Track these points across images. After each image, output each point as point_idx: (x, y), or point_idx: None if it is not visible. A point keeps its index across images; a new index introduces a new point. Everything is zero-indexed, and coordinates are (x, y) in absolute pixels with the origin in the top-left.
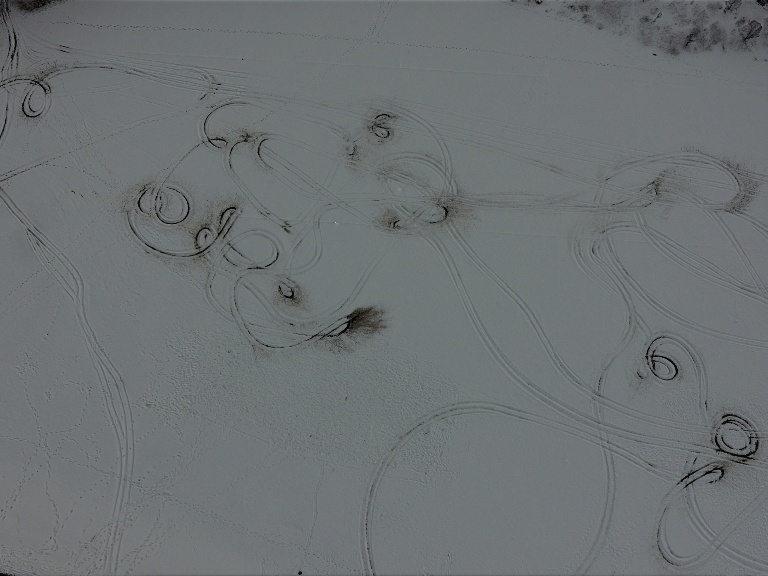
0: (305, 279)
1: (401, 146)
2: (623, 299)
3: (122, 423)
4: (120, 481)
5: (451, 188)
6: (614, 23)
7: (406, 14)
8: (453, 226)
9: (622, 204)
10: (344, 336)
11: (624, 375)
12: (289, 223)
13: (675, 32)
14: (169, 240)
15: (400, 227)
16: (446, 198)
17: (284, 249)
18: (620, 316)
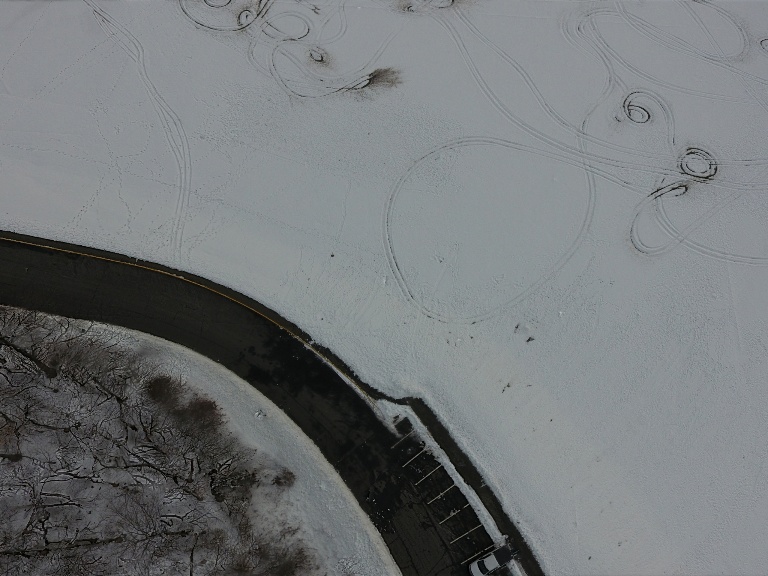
0: (333, 48)
1: None
2: (604, 64)
3: (180, 150)
4: (180, 191)
5: None
6: None
7: None
8: (459, 10)
9: None
10: (366, 89)
11: (604, 119)
12: (318, 7)
13: None
14: (215, 19)
15: (413, 11)
16: None
17: (314, 26)
18: (601, 76)
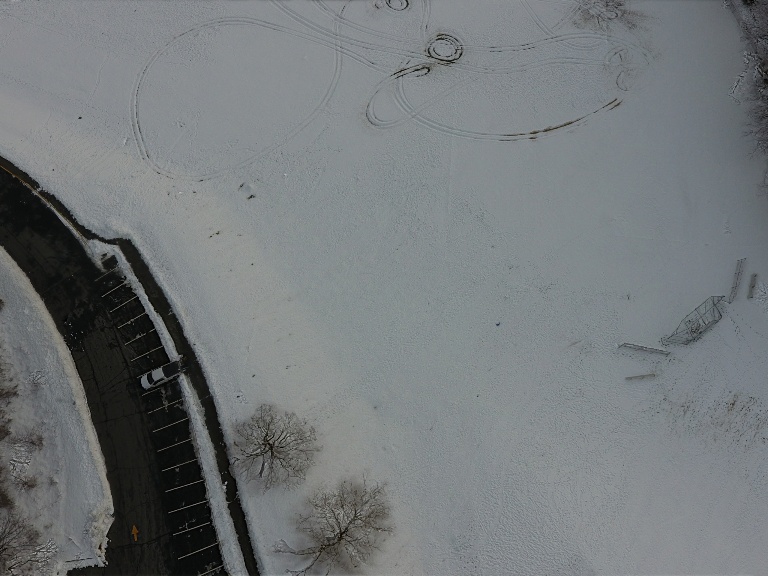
0: None
1: None
2: None
3: None
4: None
5: None
6: None
7: None
8: None
9: None
10: None
11: (364, 5)
12: None
13: None
14: None
15: None
16: None
17: None
18: None
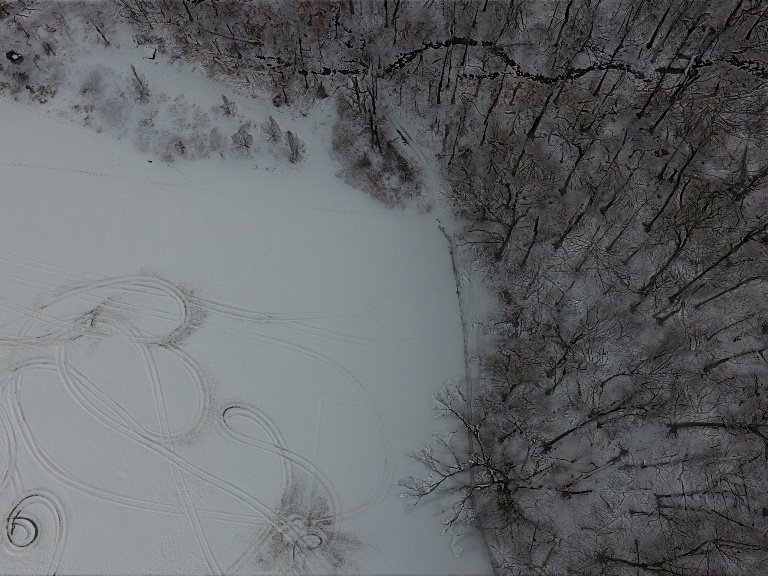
0: None
1: None
2: (8, 449)
3: None
4: None
5: None
6: (115, 126)
7: None
8: None
9: (48, 337)
10: None
11: None
12: None
13: (173, 137)
14: None
15: None
16: None
17: None
18: None
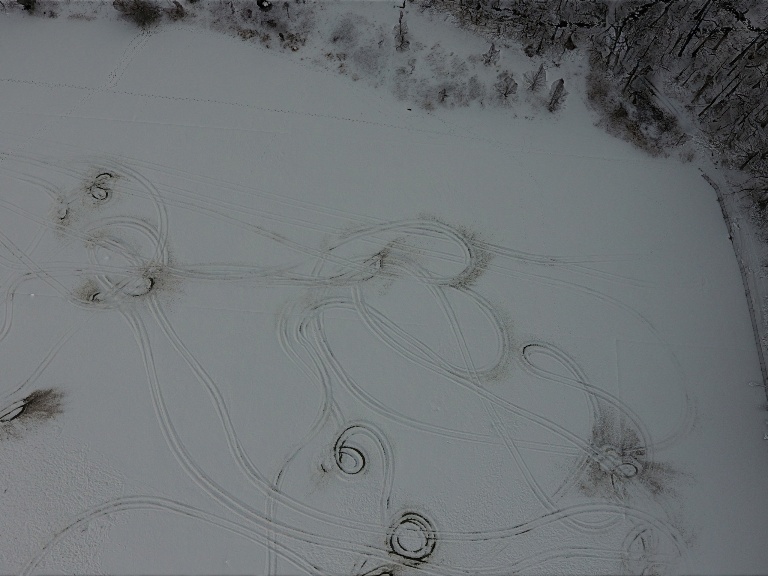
0: None
1: (117, 209)
2: (322, 383)
3: None
4: None
5: (162, 257)
6: (370, 74)
7: (151, 60)
8: (156, 300)
9: (341, 277)
10: (16, 421)
11: (306, 468)
12: None
13: (432, 85)
14: None
15: (99, 300)
16: (154, 268)
17: None
18: (315, 402)
